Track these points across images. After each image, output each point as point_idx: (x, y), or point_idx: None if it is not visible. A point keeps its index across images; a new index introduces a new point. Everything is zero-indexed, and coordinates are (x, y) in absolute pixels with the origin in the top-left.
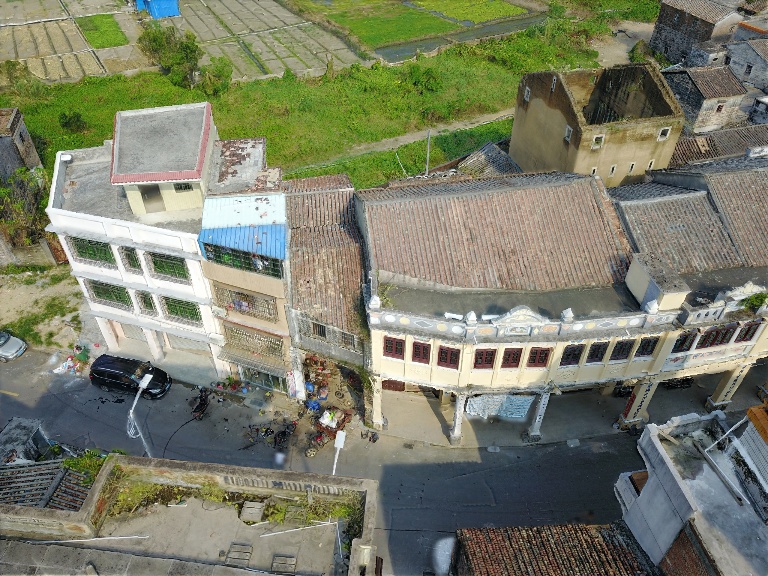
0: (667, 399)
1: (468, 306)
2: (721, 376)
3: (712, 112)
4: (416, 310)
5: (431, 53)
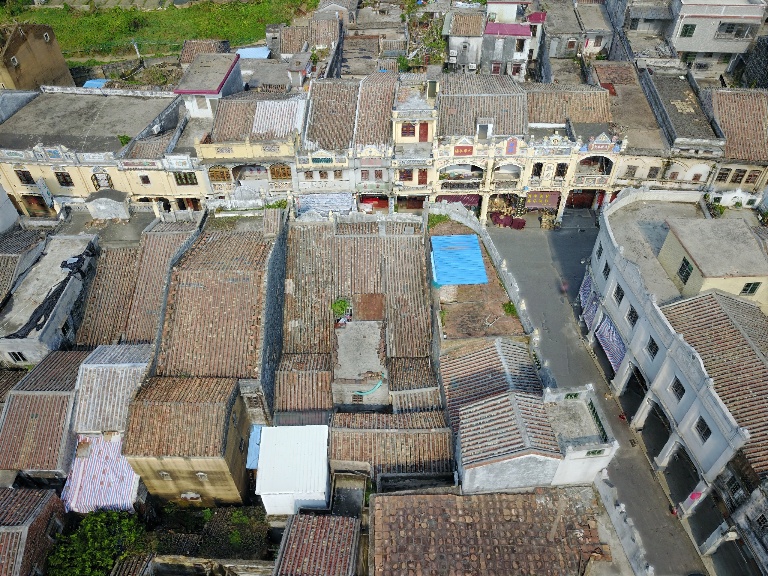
0: None
1: None
2: None
3: None
4: None
5: (183, 6)
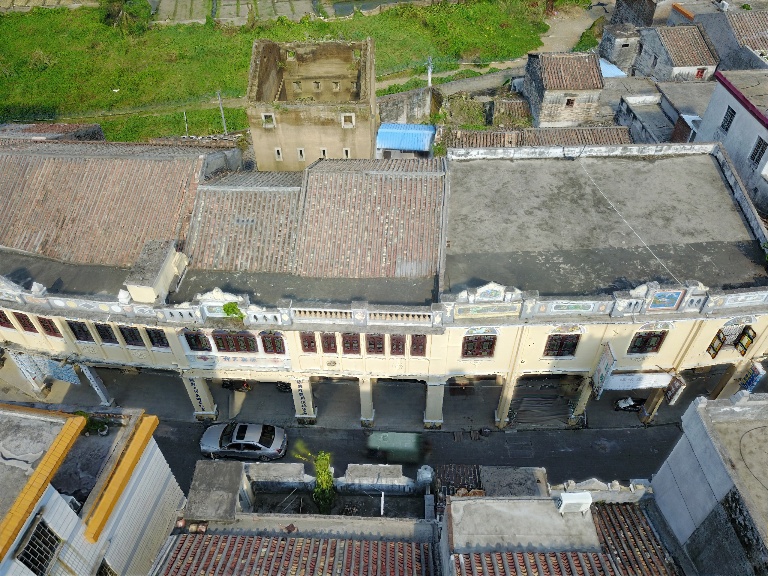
0: (271, 401)
1: (1, 265)
2: (346, 390)
3: (560, 106)
4: None
5: (372, 11)
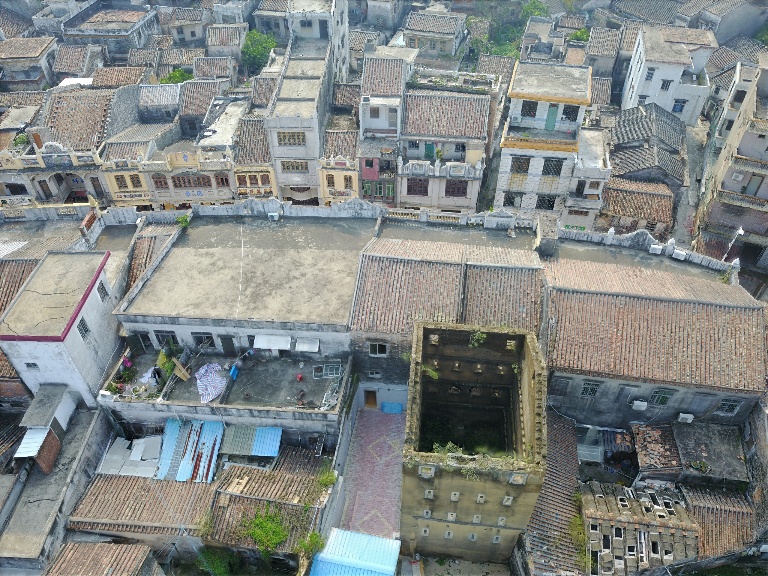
0: None
1: (664, 270)
2: None
3: None
4: (701, 276)
5: None
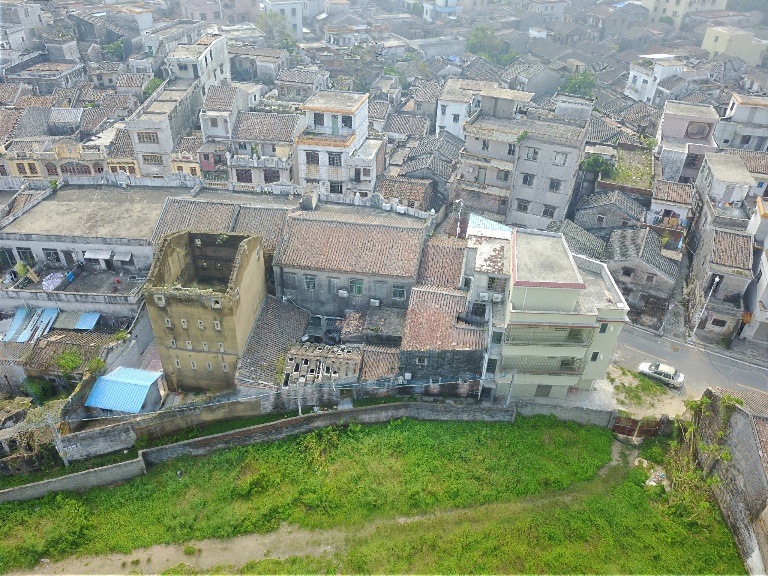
0: None
1: None
2: None
3: None
4: None
5: None
